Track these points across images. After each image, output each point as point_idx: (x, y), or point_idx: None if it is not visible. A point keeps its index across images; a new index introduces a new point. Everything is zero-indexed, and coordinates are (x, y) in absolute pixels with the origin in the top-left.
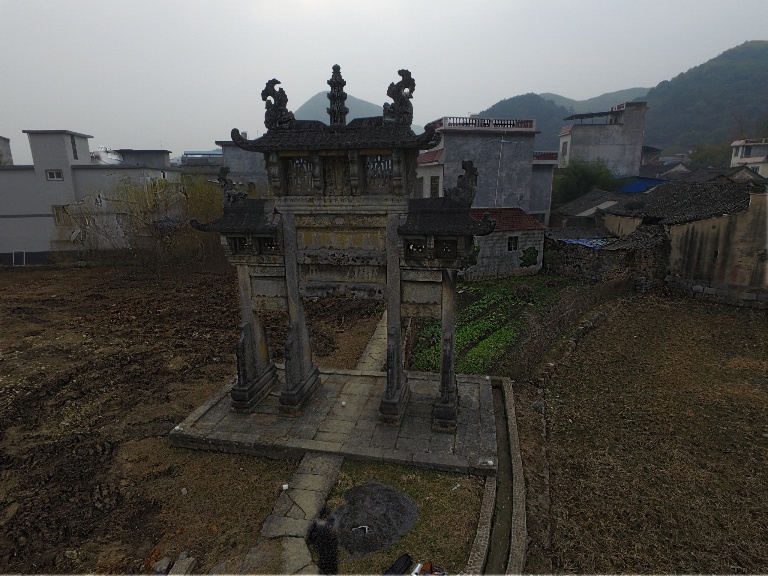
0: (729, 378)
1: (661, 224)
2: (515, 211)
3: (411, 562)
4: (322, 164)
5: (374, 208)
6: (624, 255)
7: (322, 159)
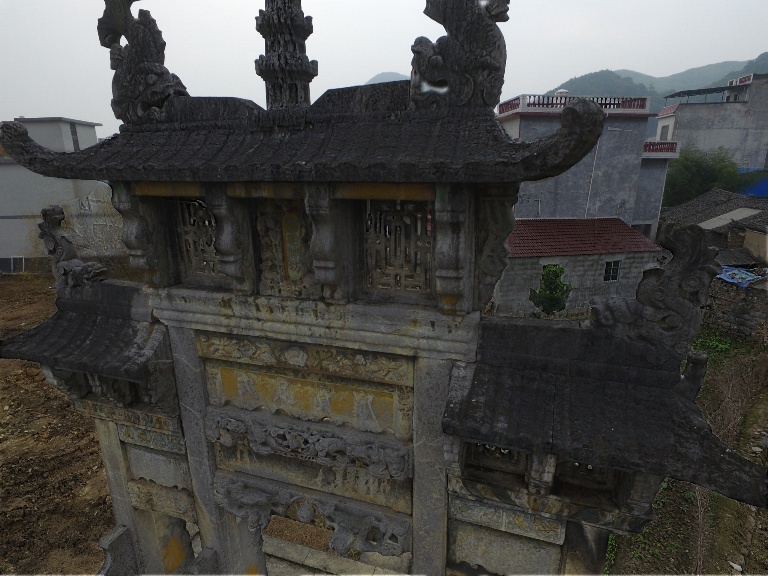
0: None
1: None
2: (614, 223)
3: None
4: (247, 215)
5: (381, 339)
6: None
7: (242, 204)
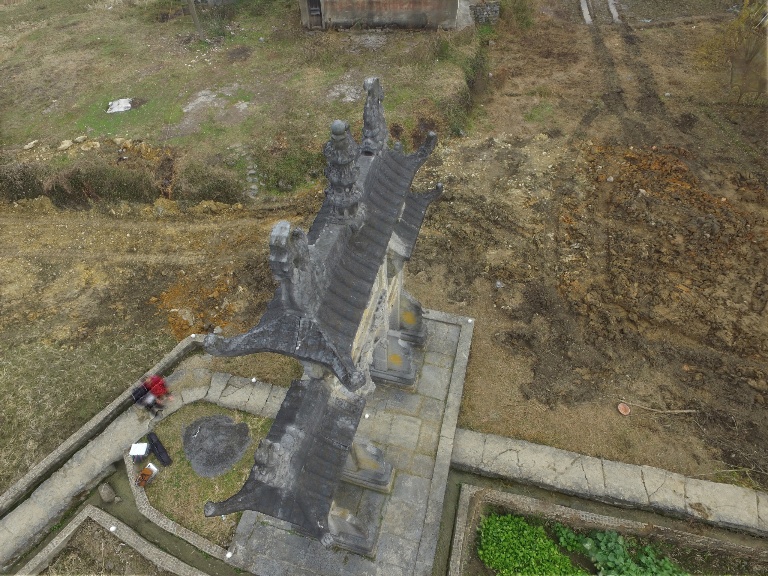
0: None
1: None
2: None
3: None
4: None
5: None
6: None
7: None
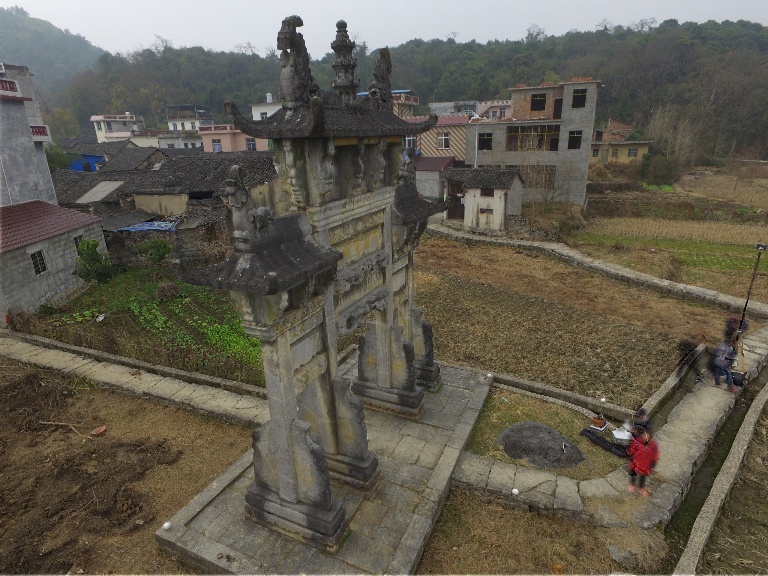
0: None
1: (217, 197)
2: (42, 205)
3: None
4: None
5: (381, 203)
6: (204, 230)
7: None
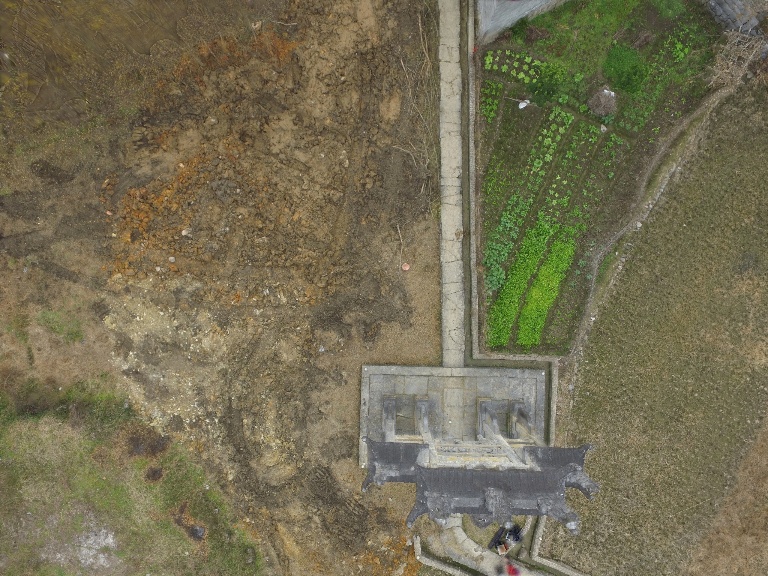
0: (719, 316)
1: None
2: None
3: None
4: None
5: None
6: None
7: None
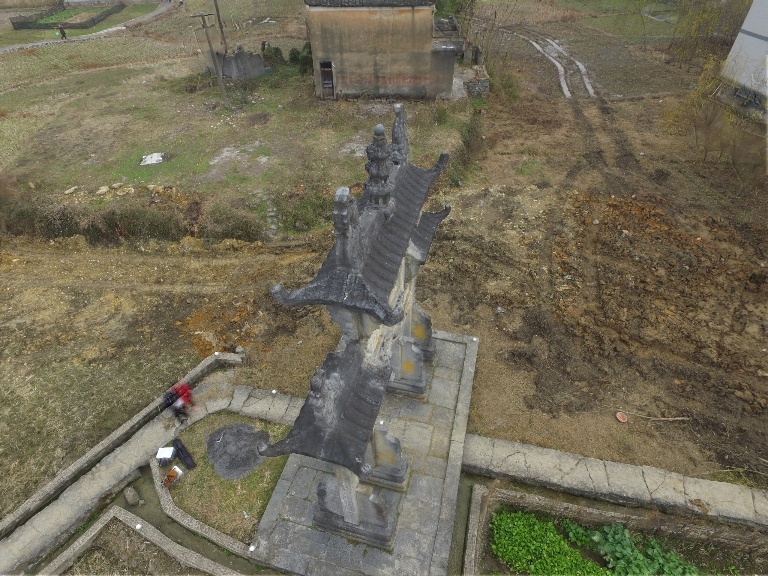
0: None
1: None
2: None
3: (189, 469)
4: None
5: None
6: None
7: None
